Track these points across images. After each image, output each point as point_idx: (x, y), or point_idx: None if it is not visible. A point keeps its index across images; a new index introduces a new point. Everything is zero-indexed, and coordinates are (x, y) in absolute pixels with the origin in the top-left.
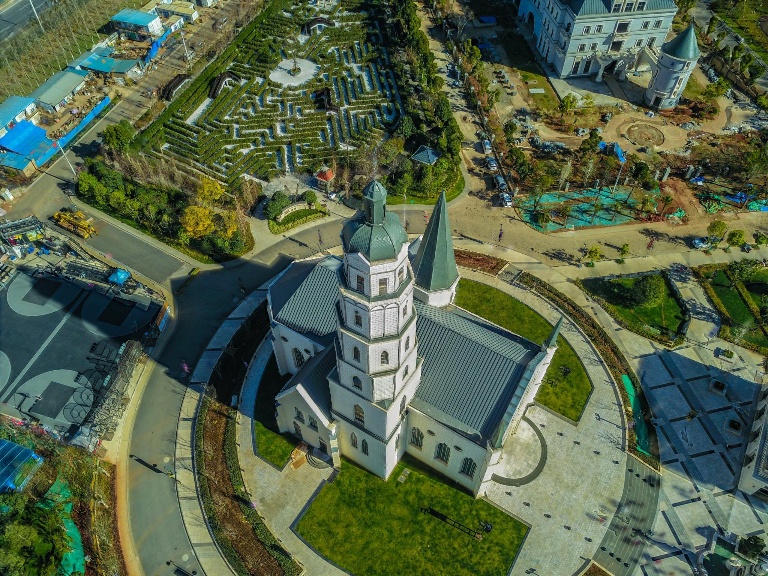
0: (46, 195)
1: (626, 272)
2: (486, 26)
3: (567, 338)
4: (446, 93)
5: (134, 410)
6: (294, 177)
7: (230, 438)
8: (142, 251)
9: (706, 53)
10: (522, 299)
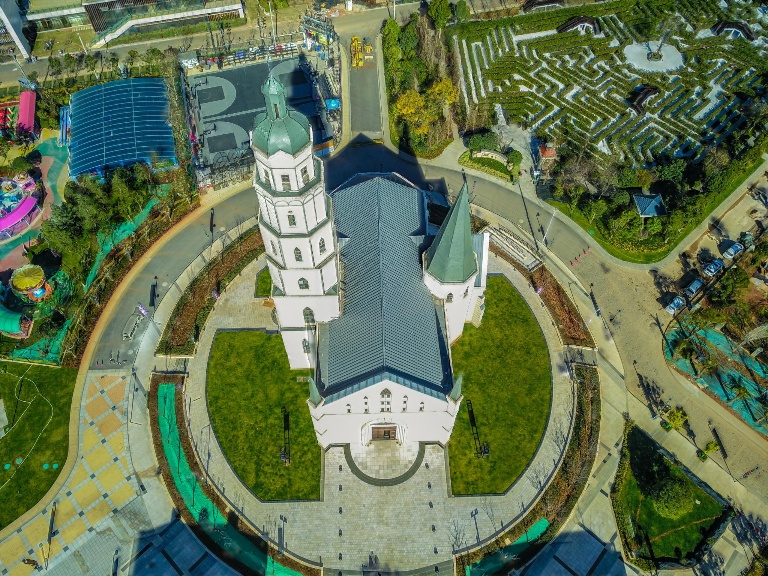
0: (370, 22)
1: (692, 469)
2: None
3: (545, 444)
4: None
5: (245, 187)
6: (530, 136)
7: (258, 251)
8: (370, 102)
9: None
10: (557, 381)
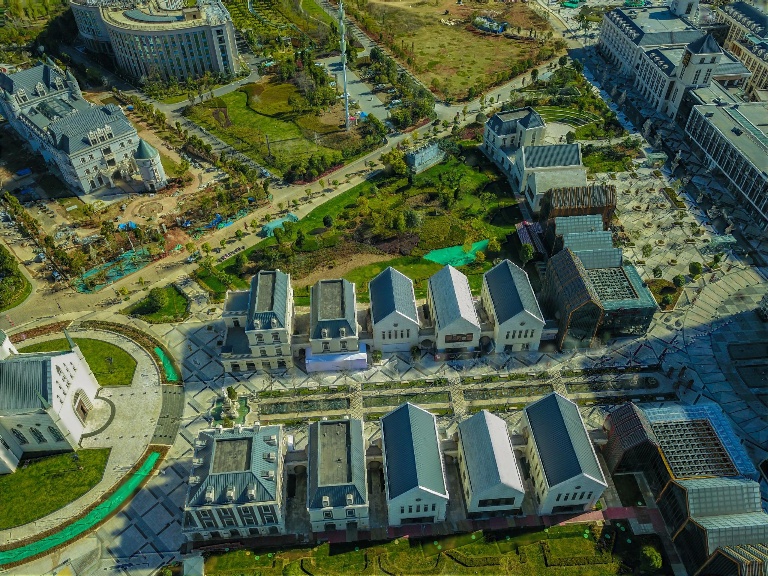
0: None
1: None
2: (24, 177)
3: (117, 345)
4: (4, 233)
5: None
6: None
7: None
8: None
9: (181, 145)
10: (85, 336)
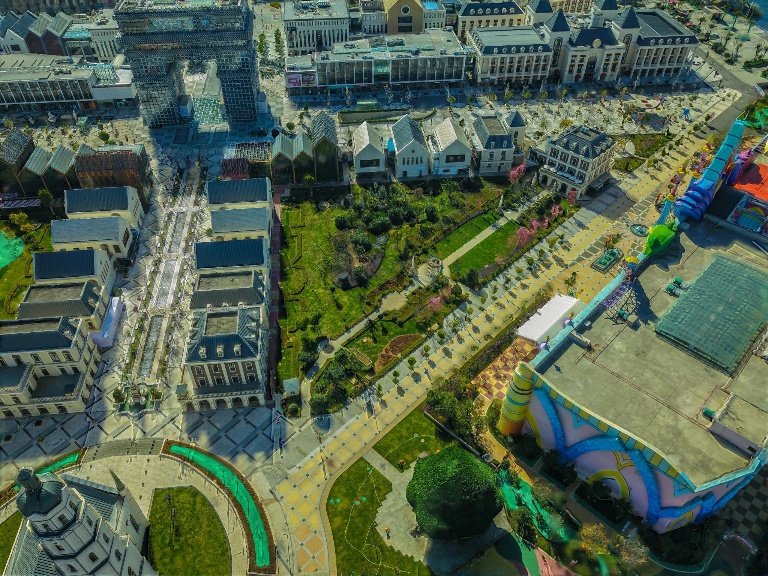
0: None
1: None
2: None
3: None
4: None
5: None
6: None
7: None
8: None
9: None
10: None
